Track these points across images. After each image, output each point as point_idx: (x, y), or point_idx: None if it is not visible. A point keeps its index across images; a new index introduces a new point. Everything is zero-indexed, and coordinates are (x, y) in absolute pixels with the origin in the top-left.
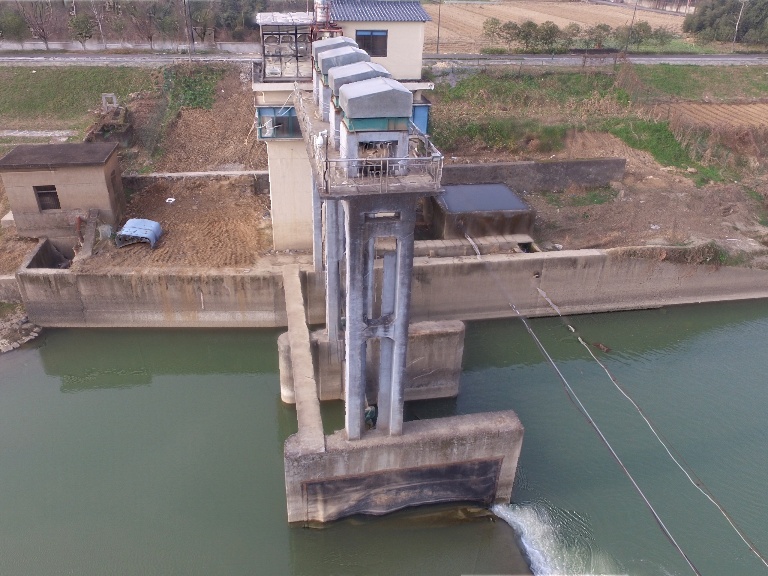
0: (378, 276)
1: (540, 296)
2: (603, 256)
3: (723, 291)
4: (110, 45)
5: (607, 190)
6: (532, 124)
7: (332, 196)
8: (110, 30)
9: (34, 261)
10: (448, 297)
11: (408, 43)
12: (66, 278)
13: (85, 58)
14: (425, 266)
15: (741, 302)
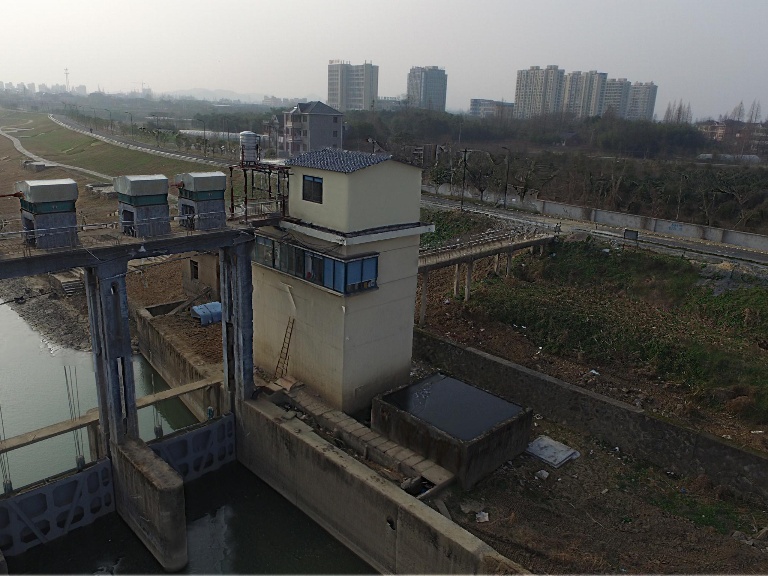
0: (260, 421)
1: (398, 559)
2: (474, 556)
3: None
4: (457, 193)
5: (766, 518)
6: (761, 373)
7: None
8: (455, 180)
9: (162, 308)
10: (311, 487)
11: (337, 193)
12: (146, 322)
13: None
14: (292, 434)
15: None
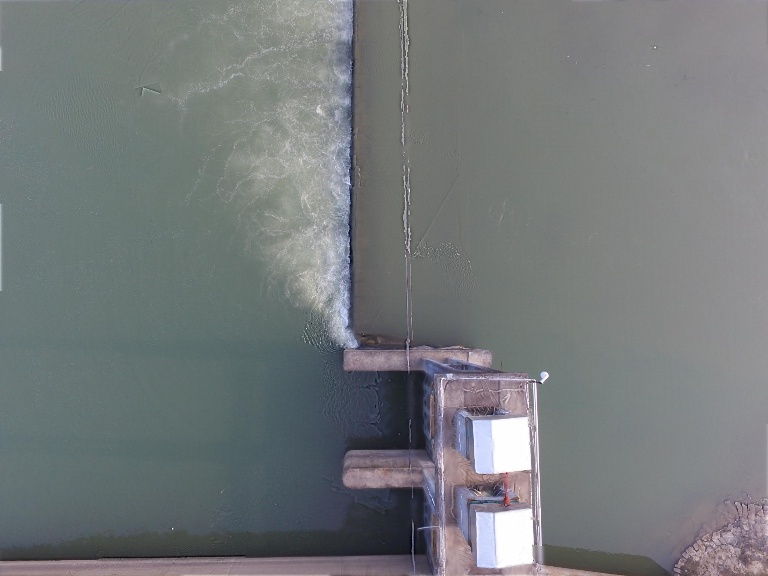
0: None
1: (229, 569)
2: None
3: (22, 567)
4: None
5: None
6: None
7: (519, 373)
8: None
9: None
10: (324, 571)
11: None
12: None
13: None
14: None
15: (6, 559)
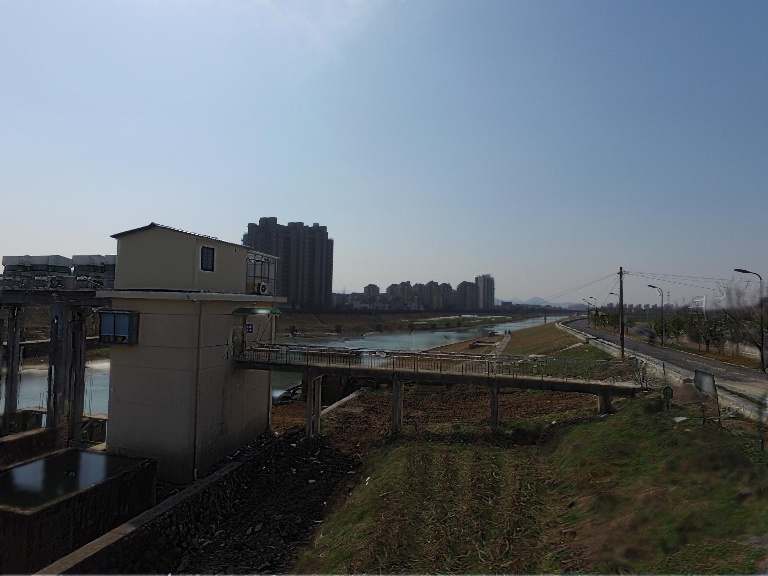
0: None
1: None
2: None
3: None
4: (749, 354)
5: None
6: None
7: None
8: None
9: None
10: None
11: None
12: None
13: (617, 346)
14: None
15: None
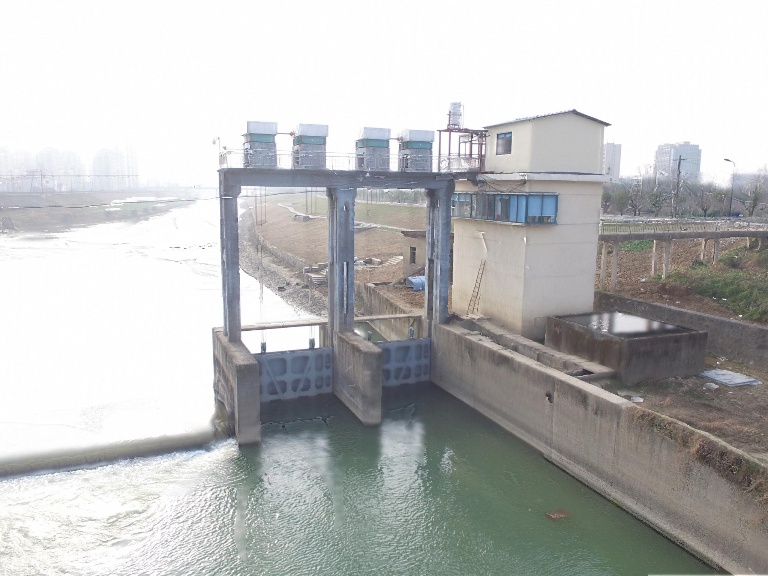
0: None
1: (555, 432)
2: (617, 407)
3: None
4: None
5: None
6: None
7: None
8: None
9: None
10: (486, 386)
11: None
12: None
13: None
14: (474, 341)
15: None
